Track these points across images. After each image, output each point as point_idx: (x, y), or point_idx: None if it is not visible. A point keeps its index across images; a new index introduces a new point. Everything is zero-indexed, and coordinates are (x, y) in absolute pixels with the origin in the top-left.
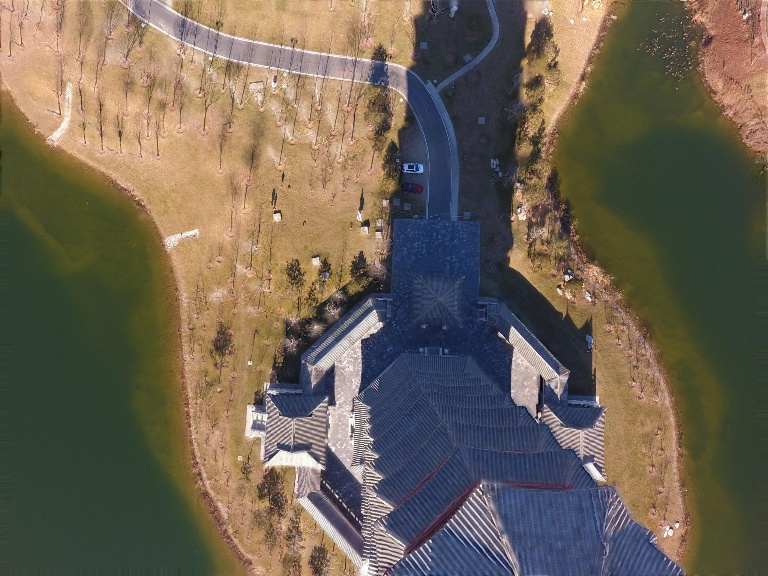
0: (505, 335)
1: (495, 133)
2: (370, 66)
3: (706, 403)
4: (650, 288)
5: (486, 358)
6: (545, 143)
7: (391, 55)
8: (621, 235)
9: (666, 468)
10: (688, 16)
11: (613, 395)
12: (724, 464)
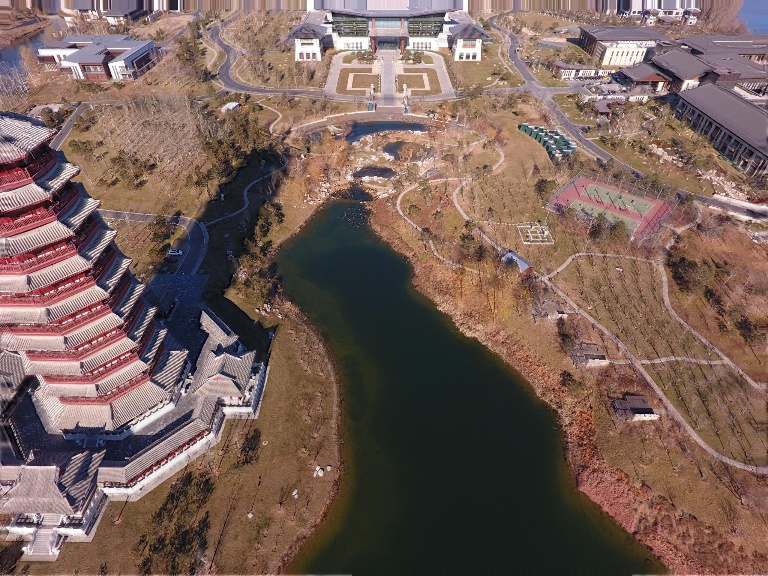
0: (198, 318)
1: (234, 241)
2: (170, 218)
3: (367, 382)
4: (330, 317)
5: (186, 340)
6: (271, 251)
7: (184, 214)
8: (314, 292)
9: (324, 422)
10: (363, 207)
11: (282, 366)
12: (382, 426)
